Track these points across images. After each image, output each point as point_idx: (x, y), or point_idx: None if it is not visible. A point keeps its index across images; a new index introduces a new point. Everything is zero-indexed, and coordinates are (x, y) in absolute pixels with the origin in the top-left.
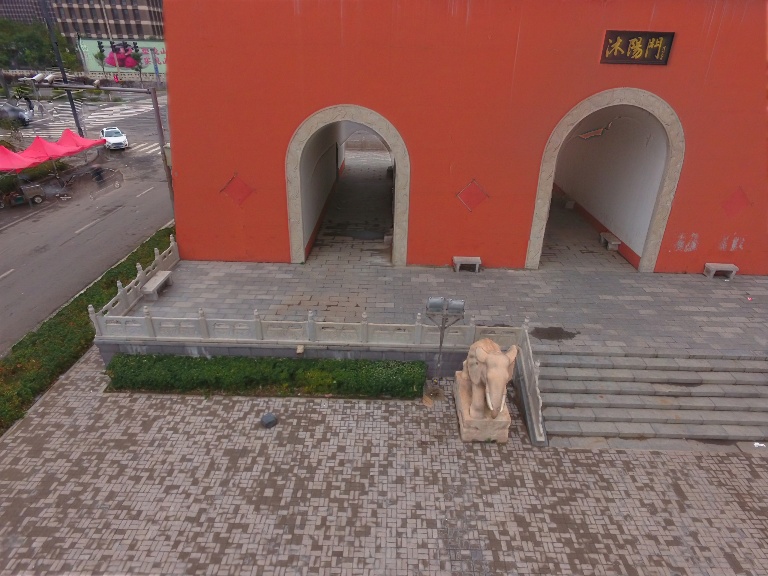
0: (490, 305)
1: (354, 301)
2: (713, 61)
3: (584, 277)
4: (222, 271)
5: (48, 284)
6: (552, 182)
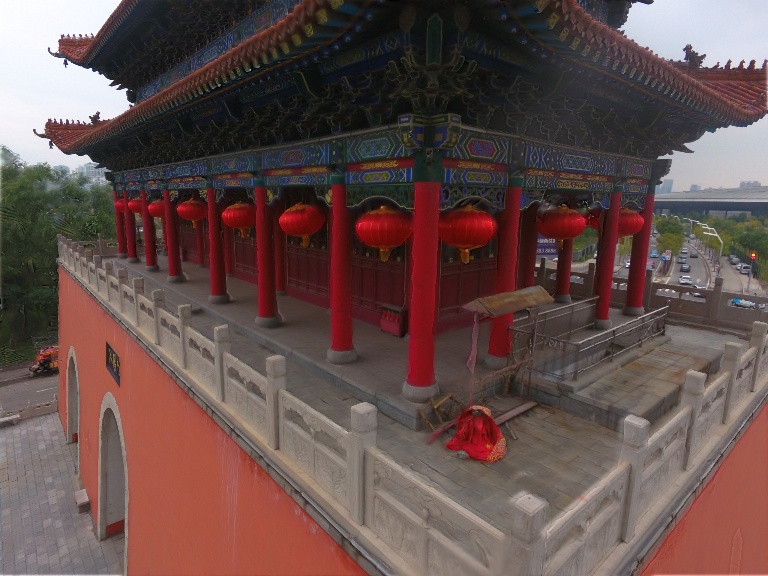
0: (2, 541)
1: (0, 484)
2: (130, 398)
3: (89, 574)
4: (43, 428)
5: (51, 399)
6: (101, 459)
